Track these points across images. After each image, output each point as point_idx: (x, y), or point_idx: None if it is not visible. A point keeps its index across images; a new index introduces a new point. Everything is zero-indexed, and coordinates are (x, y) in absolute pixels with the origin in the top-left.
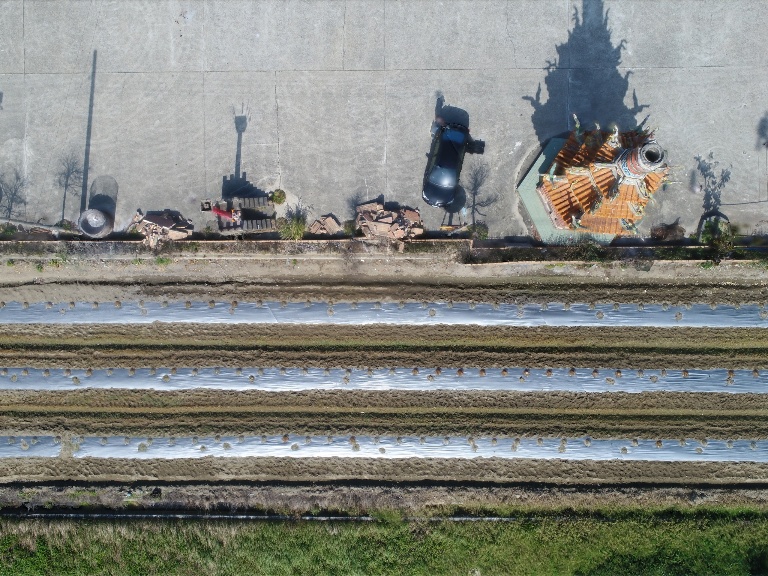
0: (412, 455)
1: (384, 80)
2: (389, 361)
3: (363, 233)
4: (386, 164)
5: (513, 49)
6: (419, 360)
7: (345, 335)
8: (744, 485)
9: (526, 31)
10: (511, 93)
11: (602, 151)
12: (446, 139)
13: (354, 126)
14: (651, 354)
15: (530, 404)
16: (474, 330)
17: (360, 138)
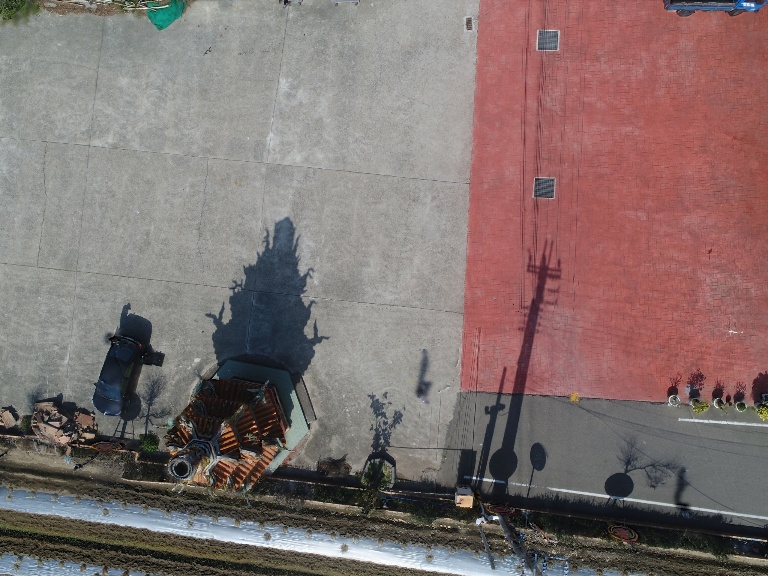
0: None
1: (75, 281)
2: (60, 554)
3: (34, 432)
4: (68, 364)
5: (202, 265)
6: (89, 556)
7: (21, 522)
8: None
9: (216, 249)
10: (195, 309)
11: (182, 431)
12: (112, 356)
13: (42, 323)
14: None
15: None
16: (144, 534)
17: (46, 336)
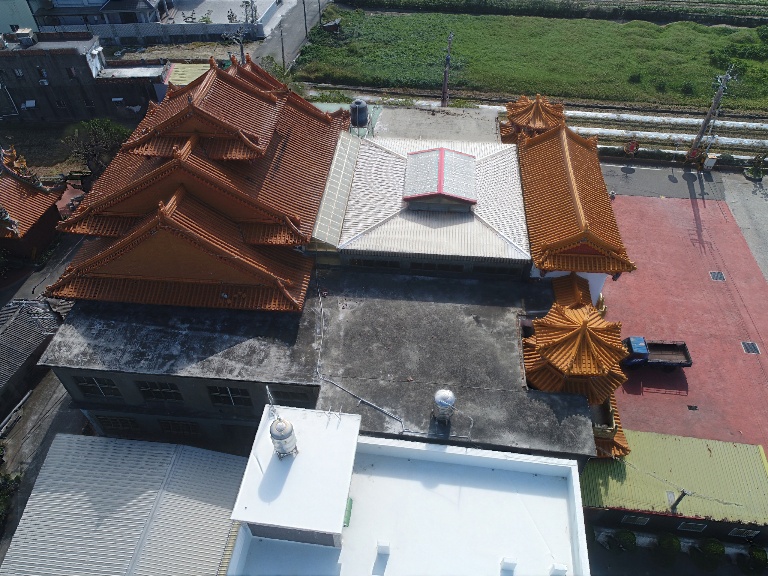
0: None
1: None
2: None
3: None
4: None
5: None
6: None
7: None
8: (698, 114)
9: None
10: None
11: None
12: None
13: None
14: (761, 150)
15: None
16: None
17: None
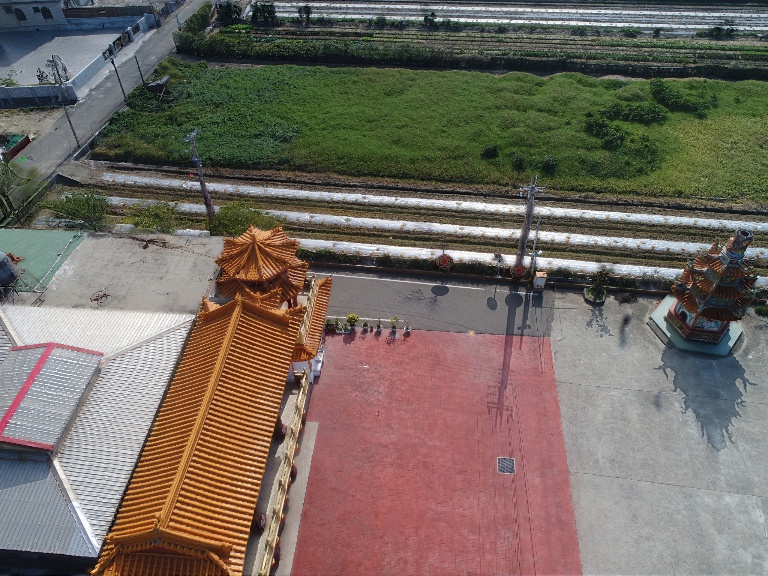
0: (759, 223)
1: None
2: None
3: None
4: None
5: None
6: None
7: None
8: (555, 200)
9: None
10: (767, 389)
11: None
12: None
13: None
14: (619, 253)
15: (691, 238)
16: None
17: None
